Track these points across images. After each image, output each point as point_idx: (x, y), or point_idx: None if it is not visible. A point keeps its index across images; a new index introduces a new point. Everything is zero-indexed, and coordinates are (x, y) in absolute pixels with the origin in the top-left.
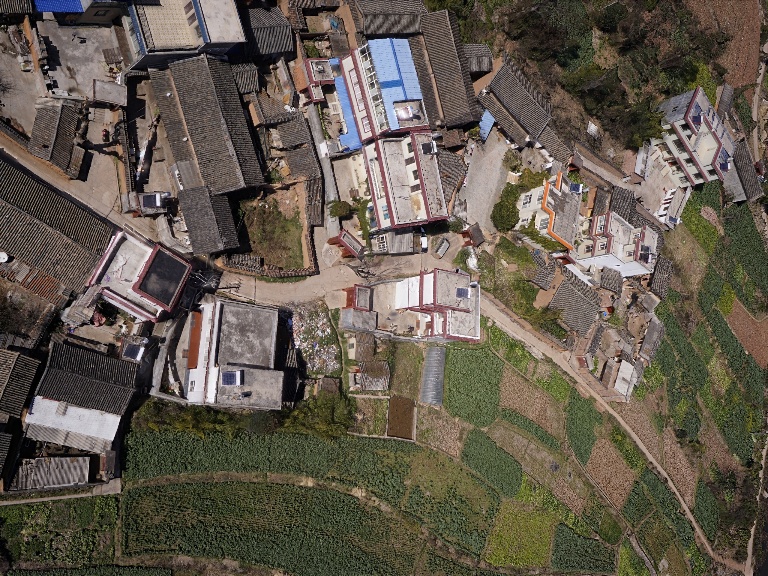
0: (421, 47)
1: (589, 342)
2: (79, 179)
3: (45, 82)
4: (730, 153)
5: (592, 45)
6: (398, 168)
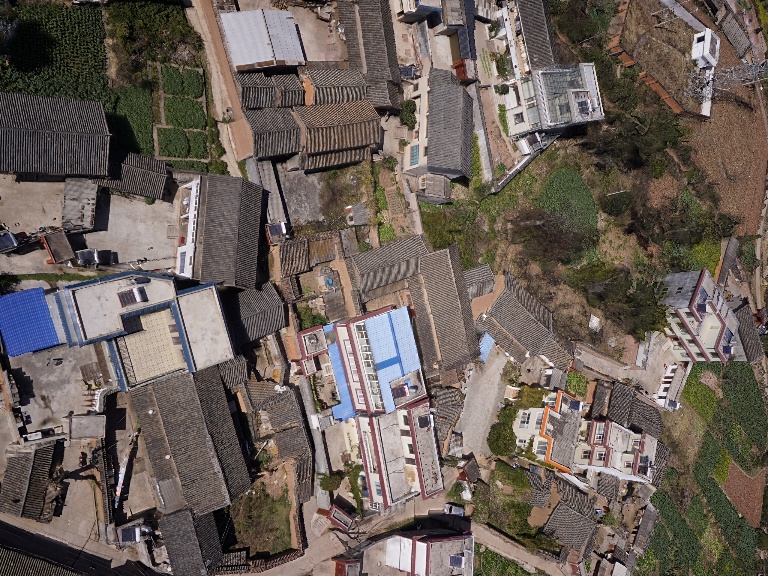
0: (420, 286)
1: (583, 548)
2: (53, 515)
3: (17, 426)
4: (733, 331)
5: (597, 230)
6: (393, 440)
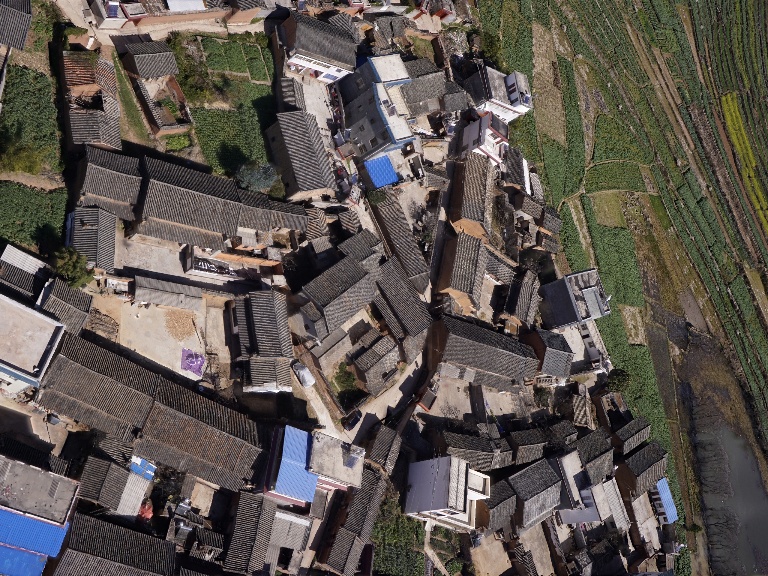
0: None
1: None
2: None
3: (416, 180)
4: None
5: None
6: None
